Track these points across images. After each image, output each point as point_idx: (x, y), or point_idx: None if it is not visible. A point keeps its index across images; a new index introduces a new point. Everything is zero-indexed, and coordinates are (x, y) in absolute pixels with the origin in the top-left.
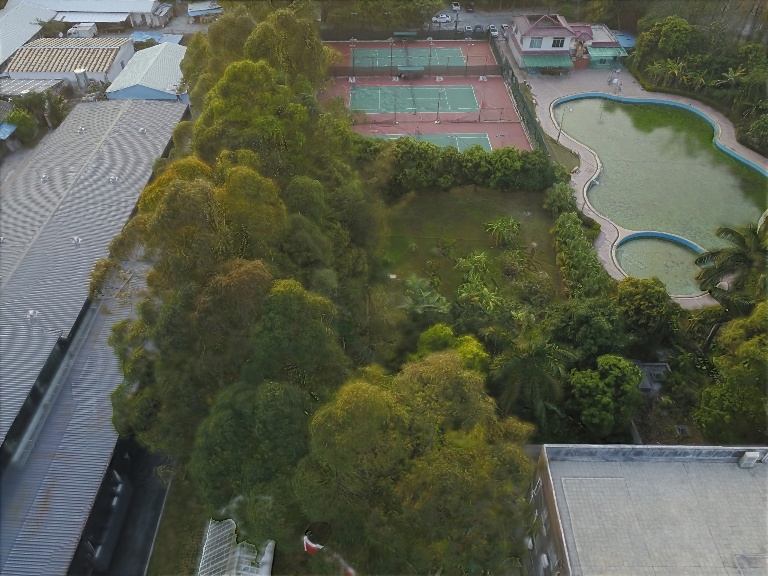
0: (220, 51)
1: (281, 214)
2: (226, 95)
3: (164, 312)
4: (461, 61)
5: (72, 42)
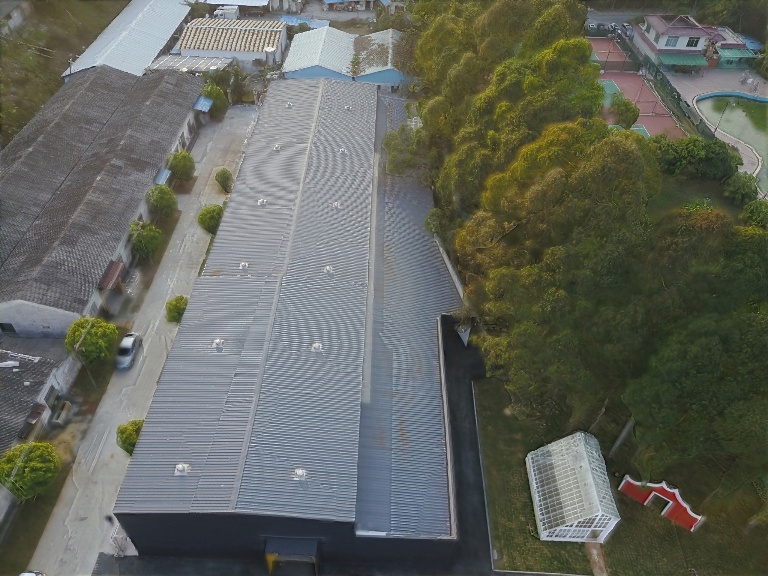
0: (498, 31)
1: (659, 176)
2: (555, 70)
3: (607, 254)
4: (594, 57)
5: (232, 23)
